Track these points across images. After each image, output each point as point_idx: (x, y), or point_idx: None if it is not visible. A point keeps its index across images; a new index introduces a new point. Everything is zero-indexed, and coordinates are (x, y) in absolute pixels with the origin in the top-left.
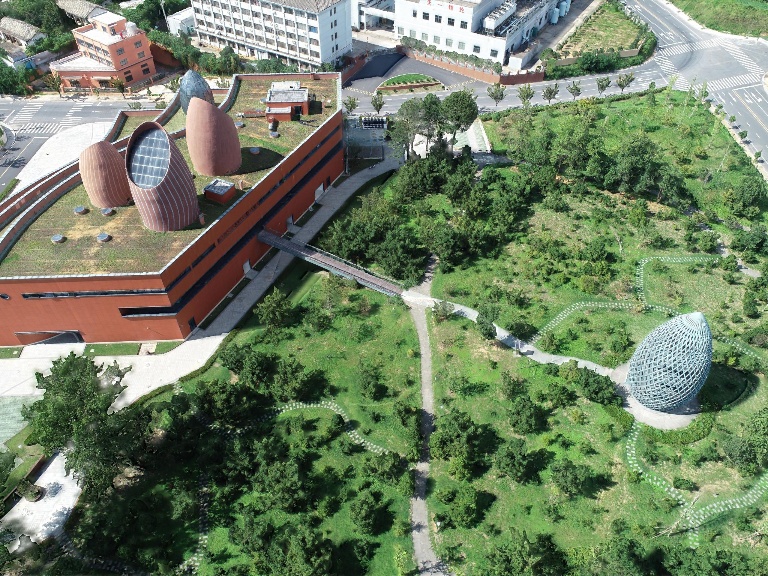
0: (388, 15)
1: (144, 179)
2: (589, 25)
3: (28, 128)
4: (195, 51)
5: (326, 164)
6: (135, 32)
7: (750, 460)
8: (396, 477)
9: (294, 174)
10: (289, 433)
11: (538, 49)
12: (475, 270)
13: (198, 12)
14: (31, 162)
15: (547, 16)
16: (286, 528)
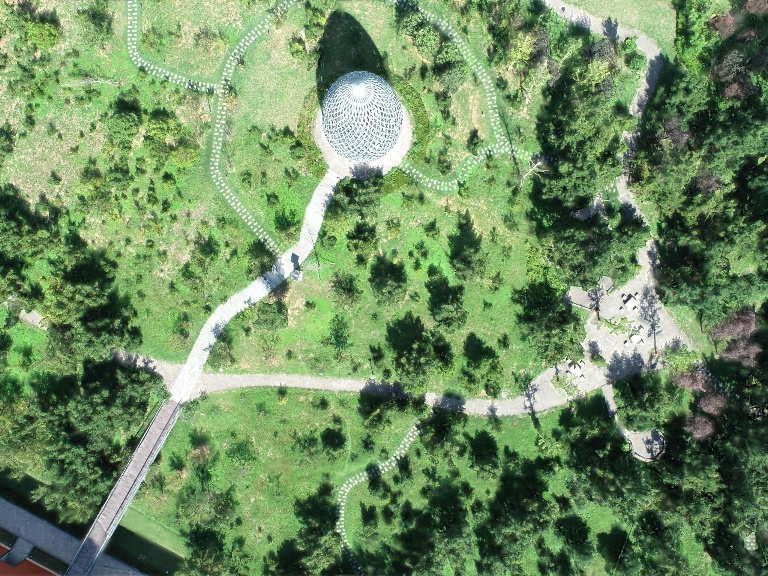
0: None
1: None
2: None
3: None
4: None
5: None
6: None
7: None
8: (453, 434)
9: None
10: (376, 534)
11: None
12: (141, 300)
13: None
14: None
15: None
16: (479, 530)
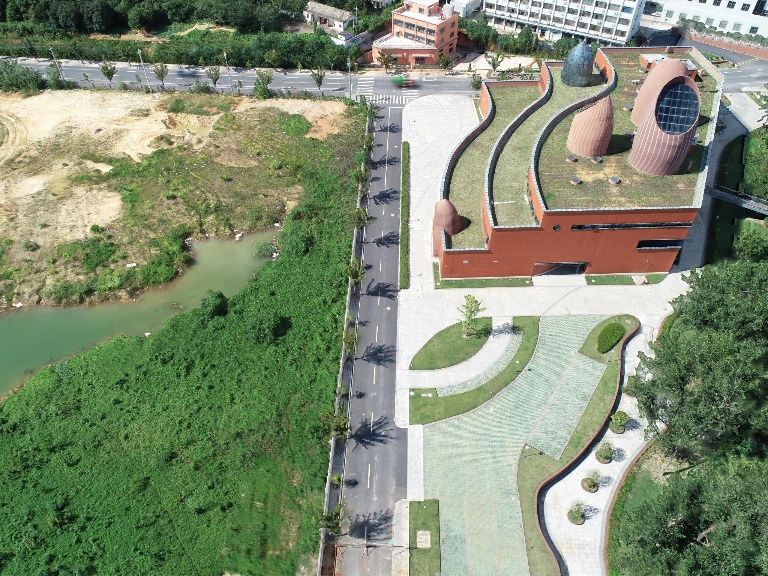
0: None
1: (670, 127)
2: None
3: (377, 99)
4: (494, 32)
5: None
6: (452, 13)
7: None
8: None
9: None
10: None
11: None
12: None
13: None
14: (405, 128)
15: None
16: None
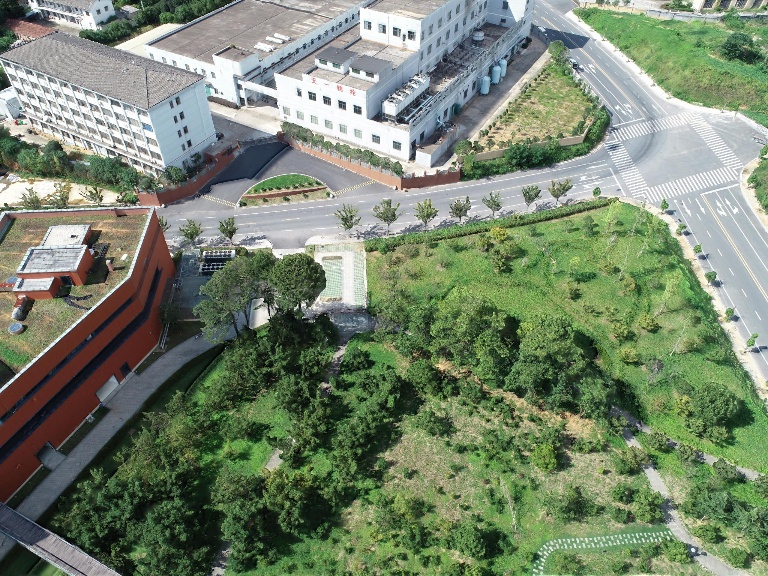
0: (269, 92)
1: None
2: (528, 96)
3: None
4: (12, 146)
5: (113, 353)
6: None
7: None
8: None
9: (36, 395)
10: None
11: (458, 134)
12: (285, 570)
13: (21, 93)
14: None
15: (475, 85)
16: None
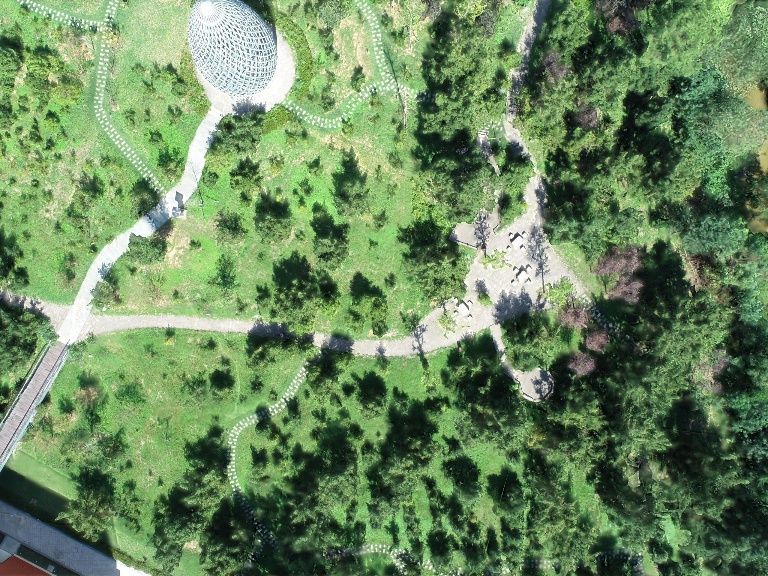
0: None
1: None
2: None
3: None
4: None
5: None
6: None
7: (340, 3)
8: (337, 372)
9: None
10: (267, 478)
11: None
12: (26, 240)
13: None
14: None
15: None
16: (370, 473)
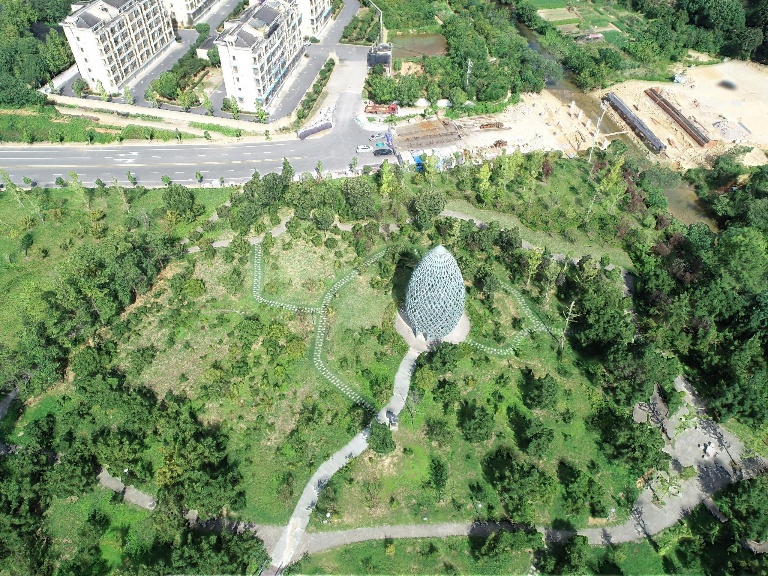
0: None
1: None
2: None
3: None
4: None
5: None
6: None
7: None
8: None
9: None
10: None
11: None
12: (249, 464)
13: None
14: None
15: None
16: None
